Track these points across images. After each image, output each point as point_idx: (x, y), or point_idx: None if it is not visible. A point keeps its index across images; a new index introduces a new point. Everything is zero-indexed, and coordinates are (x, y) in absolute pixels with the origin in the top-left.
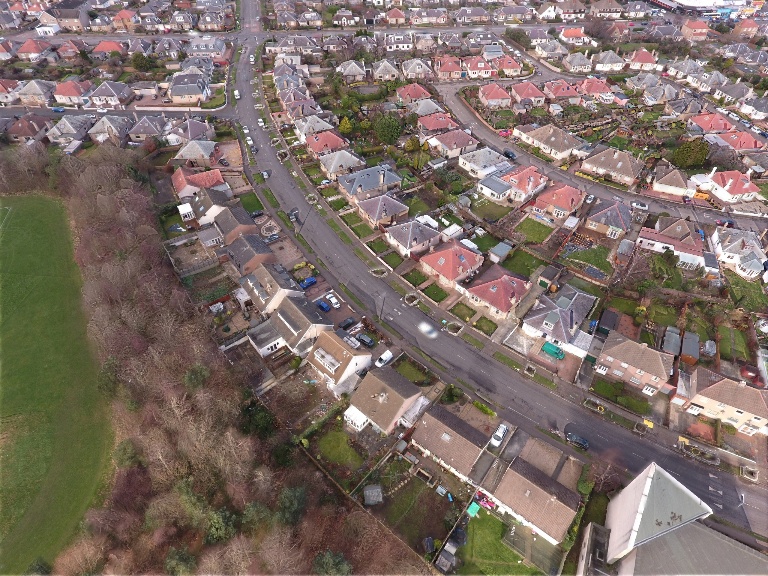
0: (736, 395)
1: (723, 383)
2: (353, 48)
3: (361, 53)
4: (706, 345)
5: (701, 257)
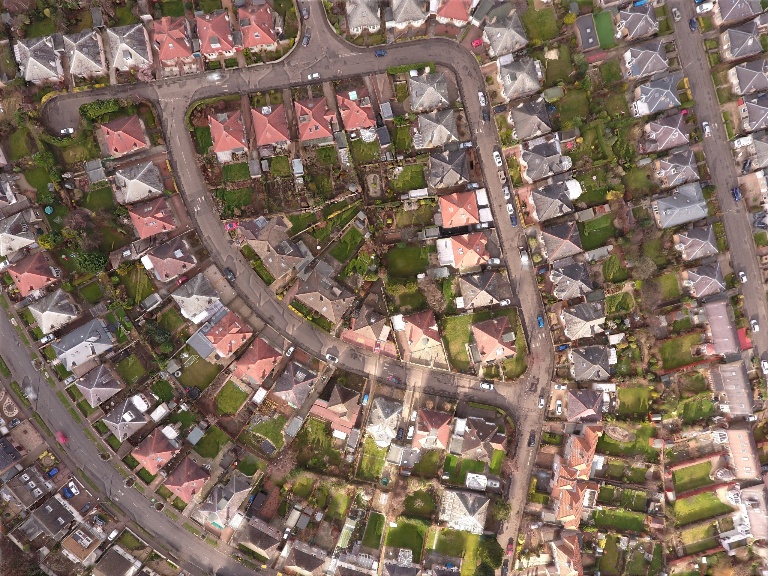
0: (301, 571)
1: (295, 567)
2: None
3: None
4: (316, 515)
5: None
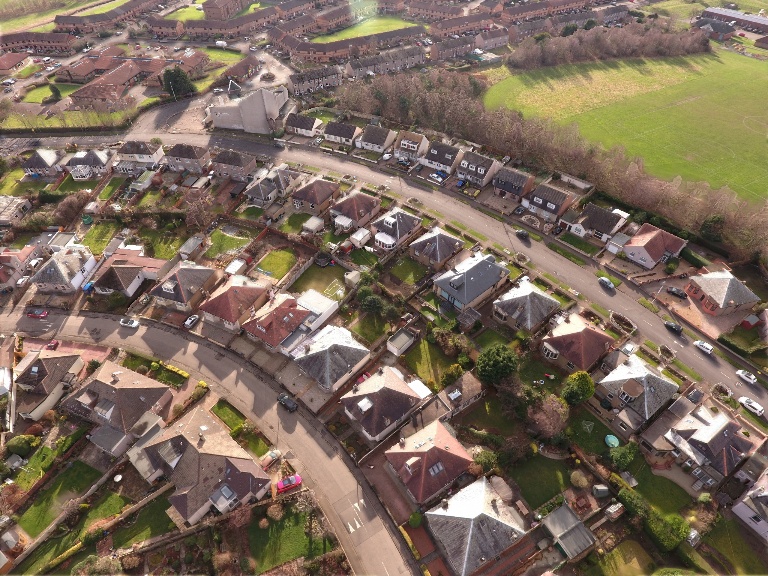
0: None
1: None
2: None
3: None
4: None
5: None
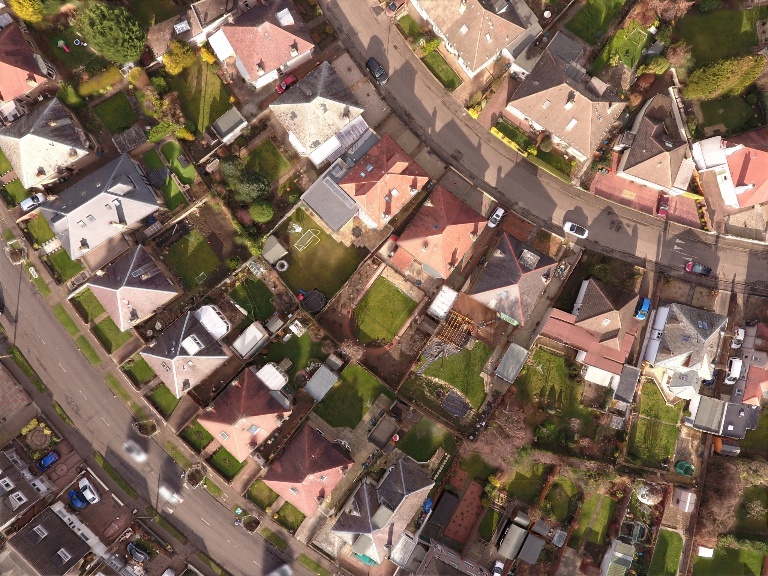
0: None
1: None
2: None
3: None
4: (555, 536)
5: (617, 375)
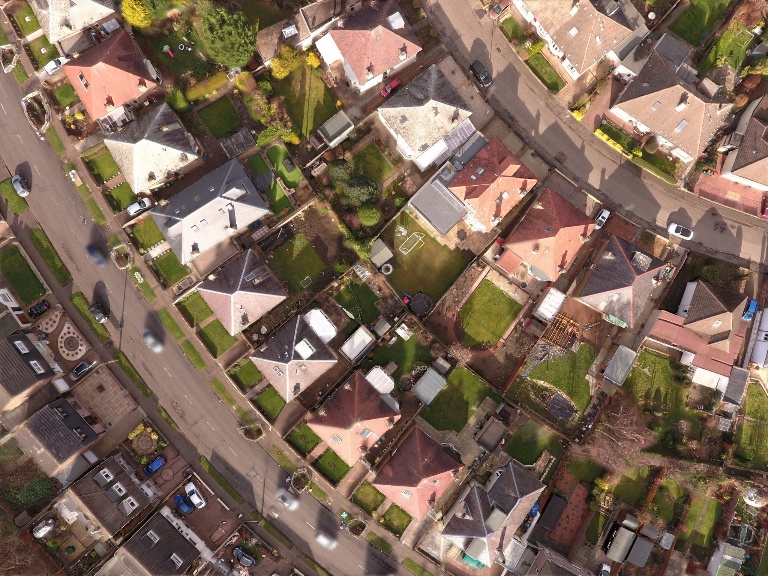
0: None
1: None
2: None
3: None
4: (663, 539)
5: (725, 377)
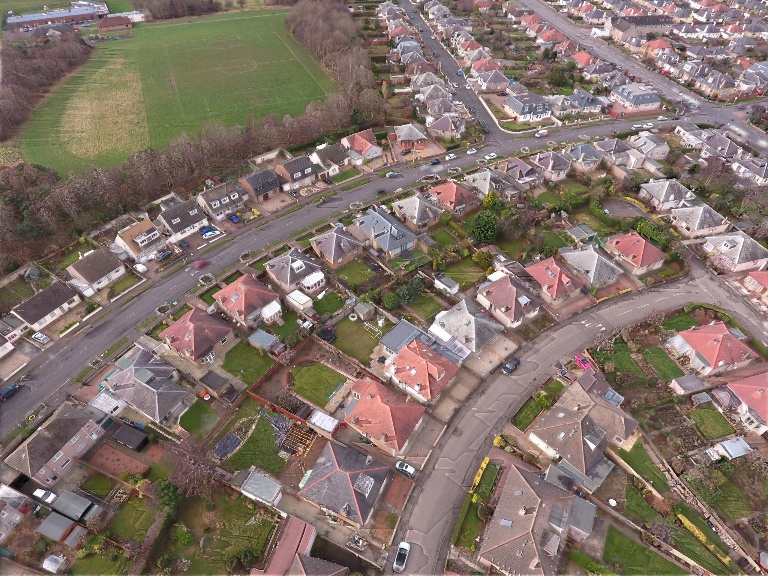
0: None
1: None
2: (758, 185)
3: (737, 191)
4: None
5: None
